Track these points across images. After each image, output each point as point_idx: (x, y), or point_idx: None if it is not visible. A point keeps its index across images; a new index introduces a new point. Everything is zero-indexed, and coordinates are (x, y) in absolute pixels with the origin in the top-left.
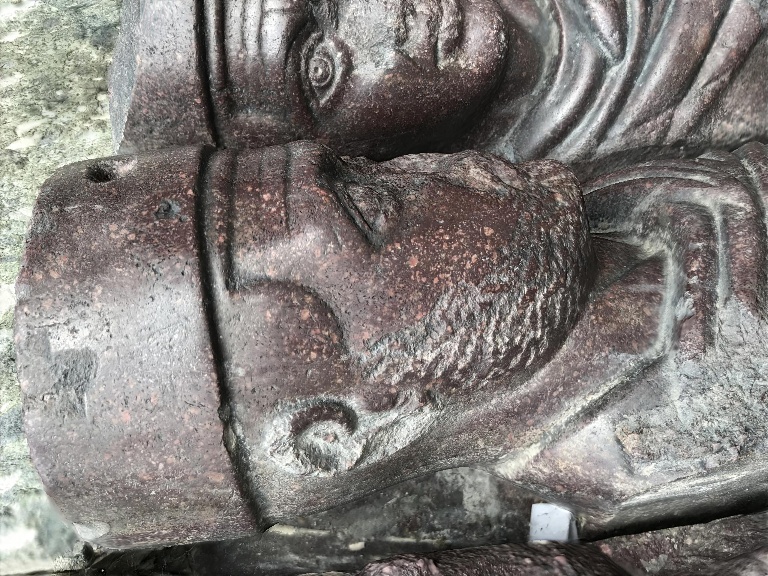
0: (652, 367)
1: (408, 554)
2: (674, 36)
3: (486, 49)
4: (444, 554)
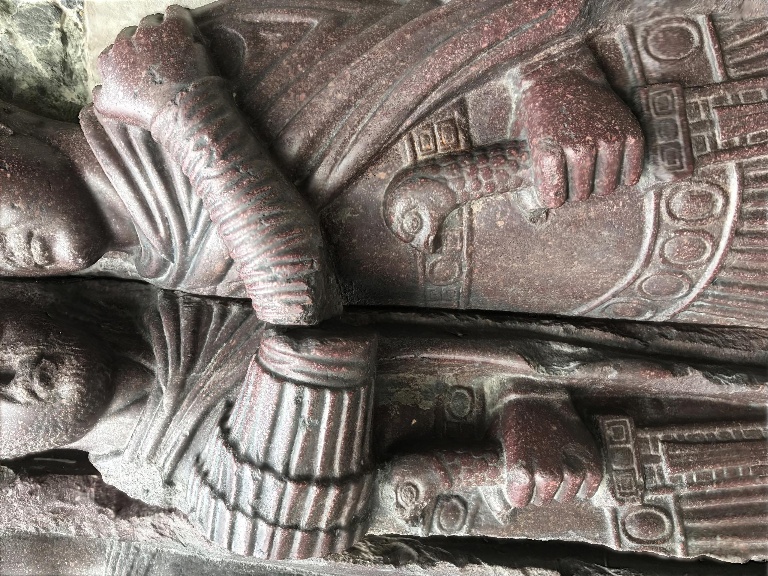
0: (116, 456)
1: (32, 478)
2: (201, 263)
3: (70, 266)
4: (49, 477)
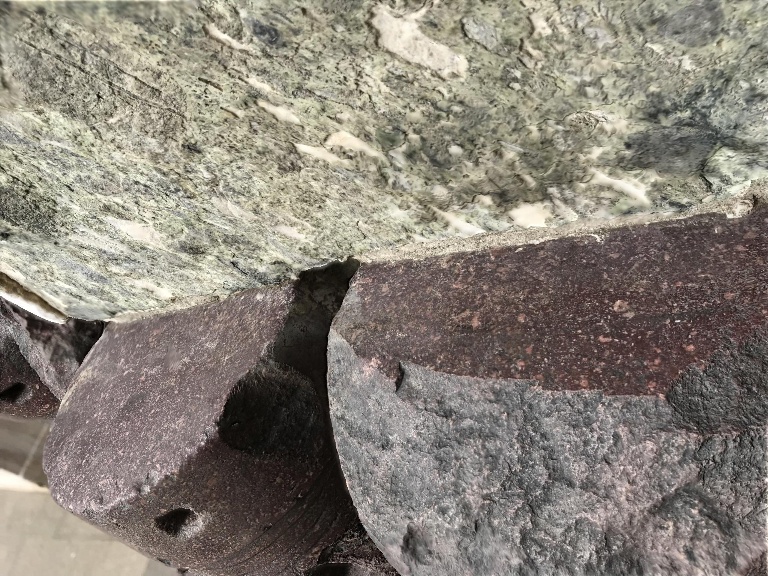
0: None
1: None
2: None
3: None
4: None
